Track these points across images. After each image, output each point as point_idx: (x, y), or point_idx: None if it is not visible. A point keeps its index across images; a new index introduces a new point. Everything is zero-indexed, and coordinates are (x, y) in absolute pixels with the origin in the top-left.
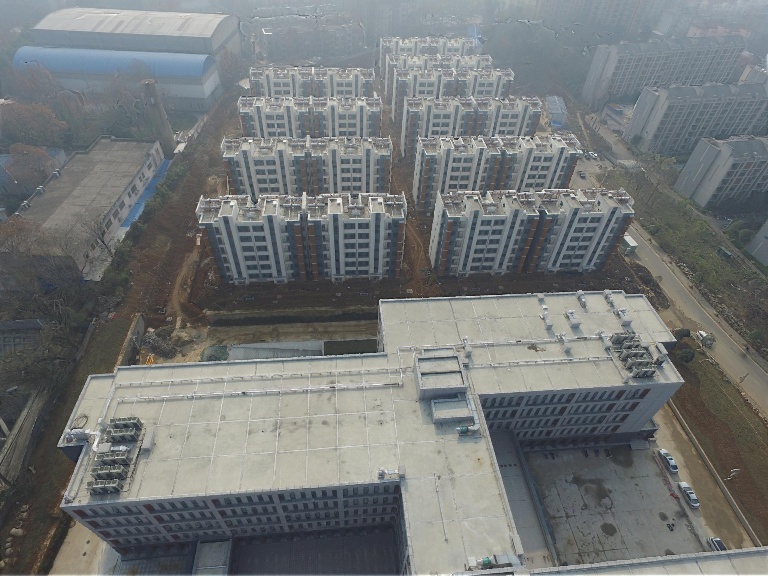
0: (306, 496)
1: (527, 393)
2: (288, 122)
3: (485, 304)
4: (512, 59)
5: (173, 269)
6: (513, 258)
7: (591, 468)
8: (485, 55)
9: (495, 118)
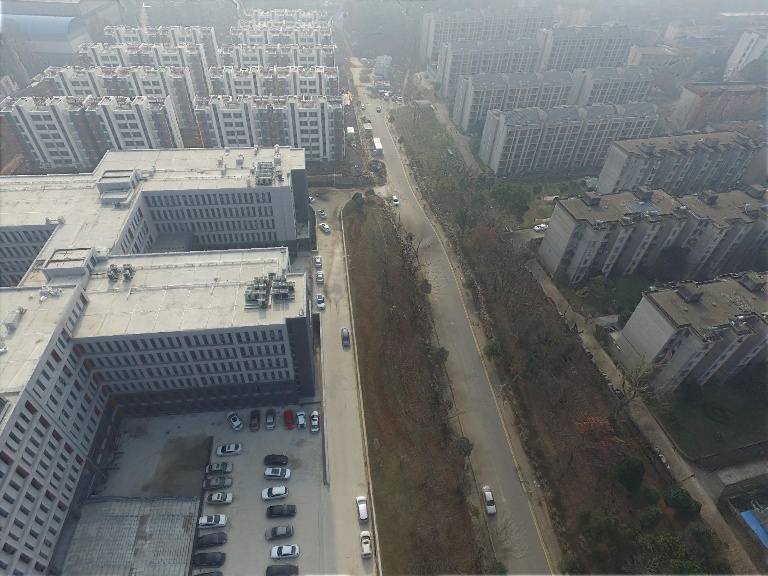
0: (3, 240)
1: (178, 192)
2: (121, 62)
3: (185, 153)
4: (369, 31)
5: (2, 163)
6: None
7: None
8: (324, 21)
9: (295, 60)
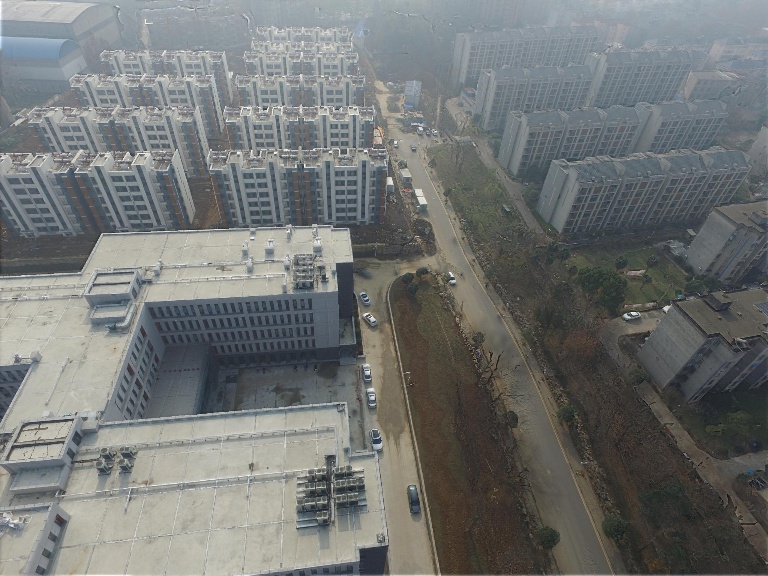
0: None
1: (192, 301)
2: (120, 97)
3: (199, 236)
4: (393, 49)
5: None
6: (290, 211)
7: (295, 380)
8: (347, 42)
9: (320, 94)
